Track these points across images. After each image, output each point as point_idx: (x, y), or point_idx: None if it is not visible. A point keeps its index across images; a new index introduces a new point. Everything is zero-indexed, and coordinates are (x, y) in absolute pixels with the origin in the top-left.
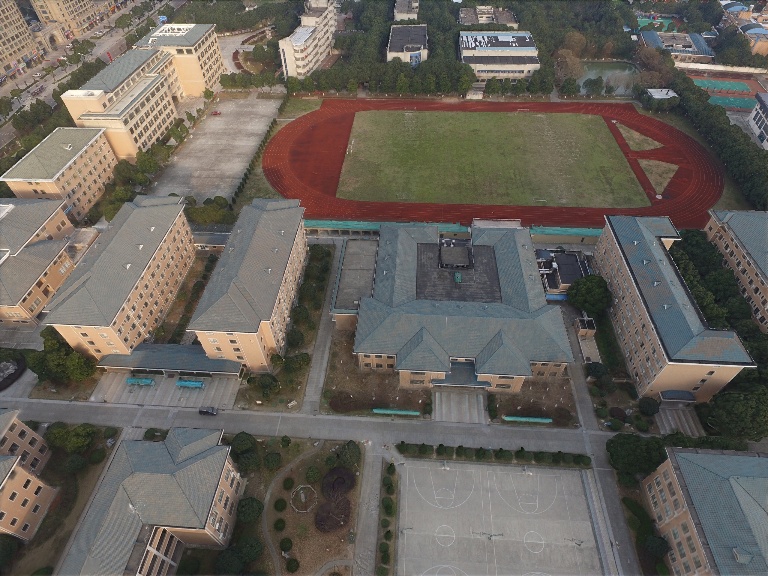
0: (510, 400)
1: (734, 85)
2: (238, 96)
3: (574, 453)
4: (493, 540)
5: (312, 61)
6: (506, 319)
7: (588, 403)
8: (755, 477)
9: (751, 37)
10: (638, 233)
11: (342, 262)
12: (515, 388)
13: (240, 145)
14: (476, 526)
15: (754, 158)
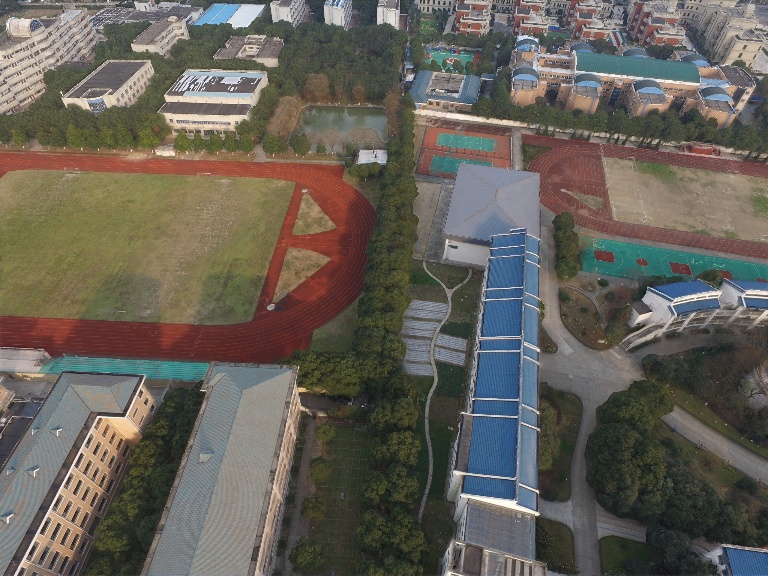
0: None
1: (480, 142)
2: None
3: None
4: None
5: None
6: None
7: None
8: None
9: (515, 84)
10: (49, 414)
11: None
12: None
13: None
14: None
15: (383, 261)
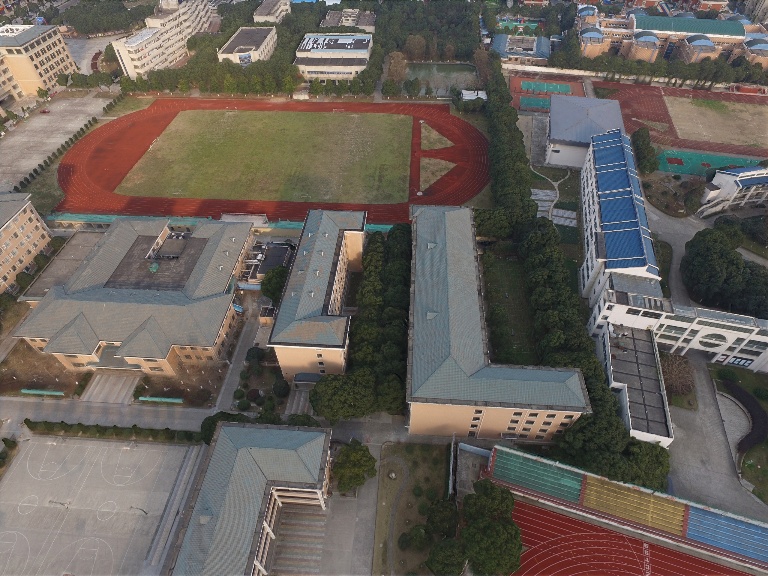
0: (163, 382)
1: (557, 87)
2: (76, 95)
3: (193, 431)
4: (70, 509)
5: (154, 62)
6: (159, 305)
7: (234, 385)
8: (267, 448)
9: (584, 41)
10: (317, 226)
11: (58, 253)
12: (169, 371)
13: (51, 142)
14: (62, 496)
15: (507, 157)
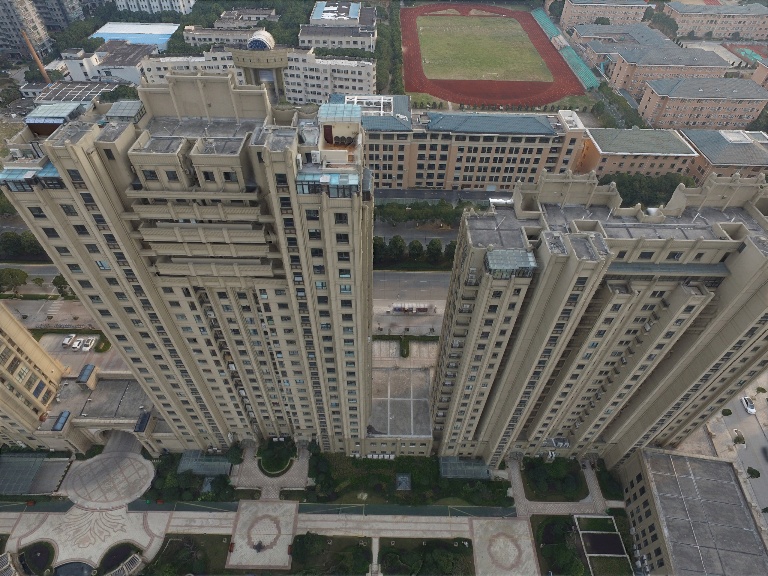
0: None
1: None
2: None
3: None
4: None
5: None
6: None
7: None
8: None
9: None
10: None
11: None
12: None
13: None
14: None
15: None
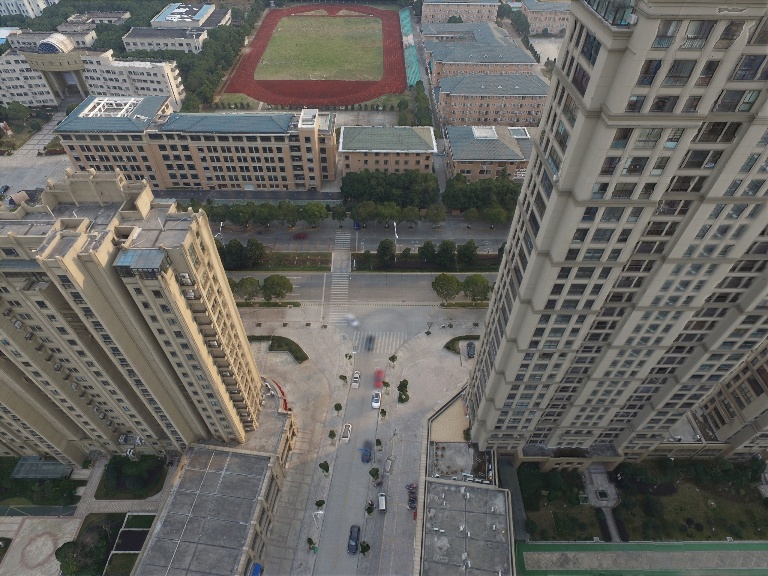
0: None
1: None
2: None
3: None
4: None
5: None
6: None
7: None
8: None
9: None
10: None
11: None
12: None
13: None
14: None
15: None
